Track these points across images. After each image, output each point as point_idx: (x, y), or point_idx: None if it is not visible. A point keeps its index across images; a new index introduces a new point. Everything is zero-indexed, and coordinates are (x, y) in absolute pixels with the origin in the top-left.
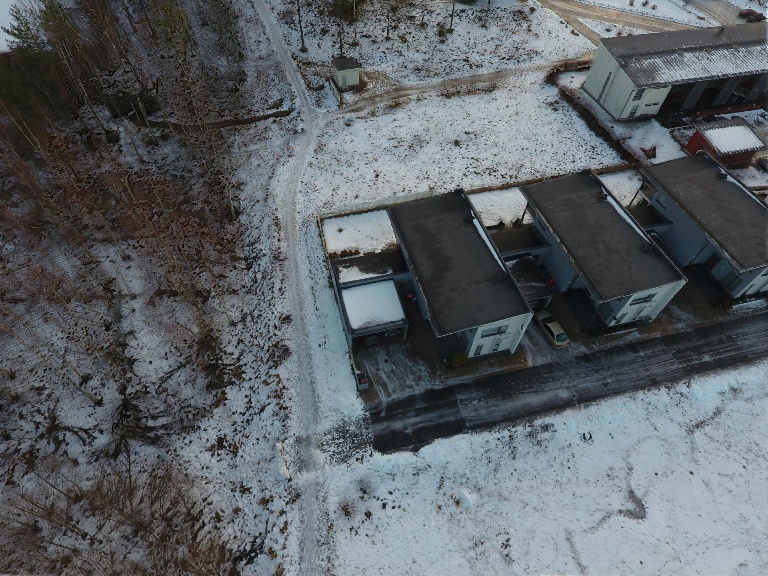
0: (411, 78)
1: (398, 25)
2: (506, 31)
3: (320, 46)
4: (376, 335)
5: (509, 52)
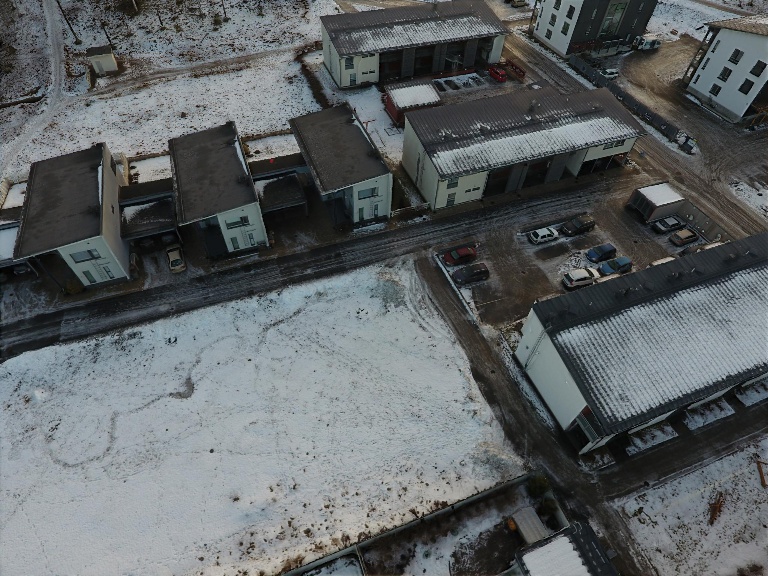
0: (173, 63)
1: (178, 17)
2: (281, 18)
3: (95, 38)
4: (3, 273)
5: (275, 36)
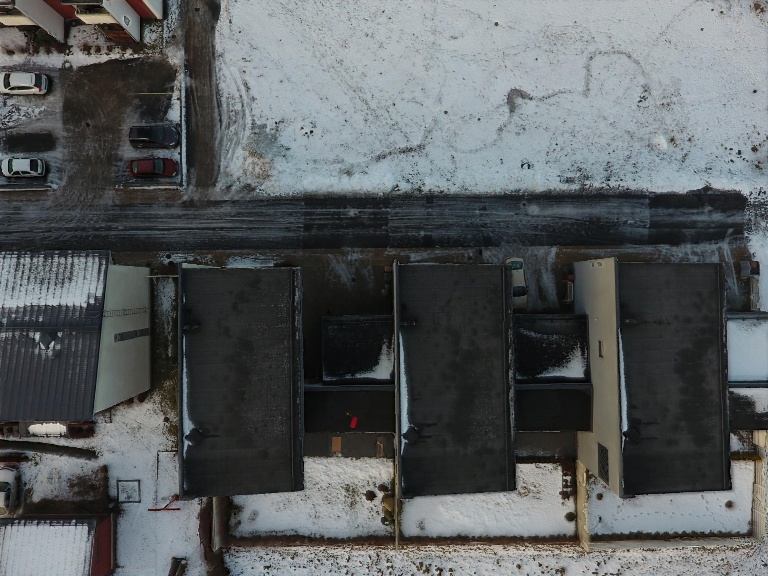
0: None
1: None
2: None
3: None
4: None
5: None
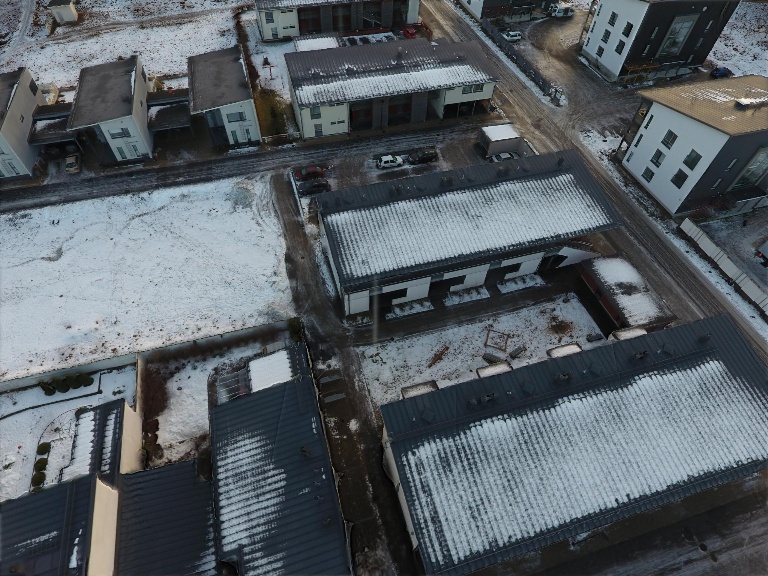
0: (127, 16)
1: None
2: None
3: None
4: None
5: None
